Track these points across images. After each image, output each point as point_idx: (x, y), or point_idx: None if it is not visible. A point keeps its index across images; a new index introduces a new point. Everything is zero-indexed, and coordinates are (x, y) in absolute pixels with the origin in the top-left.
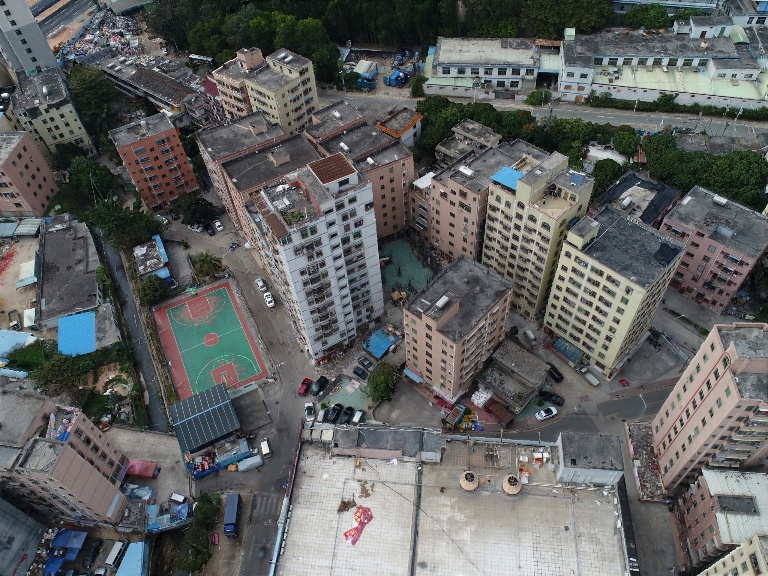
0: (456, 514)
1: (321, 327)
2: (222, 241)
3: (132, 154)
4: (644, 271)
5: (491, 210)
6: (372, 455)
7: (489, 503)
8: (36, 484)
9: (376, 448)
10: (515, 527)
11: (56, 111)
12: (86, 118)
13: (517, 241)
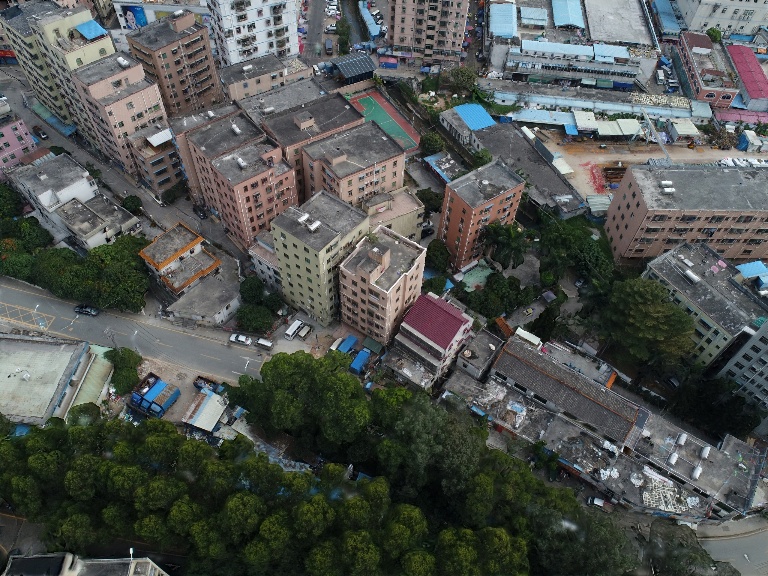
0: None
1: None
2: None
3: None
4: (36, 8)
5: None
6: None
7: None
8: None
9: None
10: None
11: None
12: None
13: None
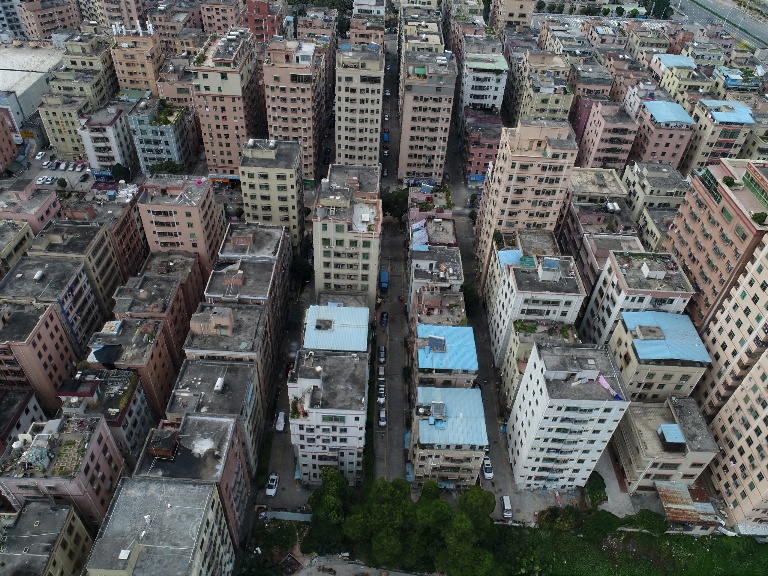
0: (8, 51)
1: None
2: None
3: None
4: None
5: None
6: None
7: None
8: None
9: None
10: (29, 53)
11: None
12: None
13: None
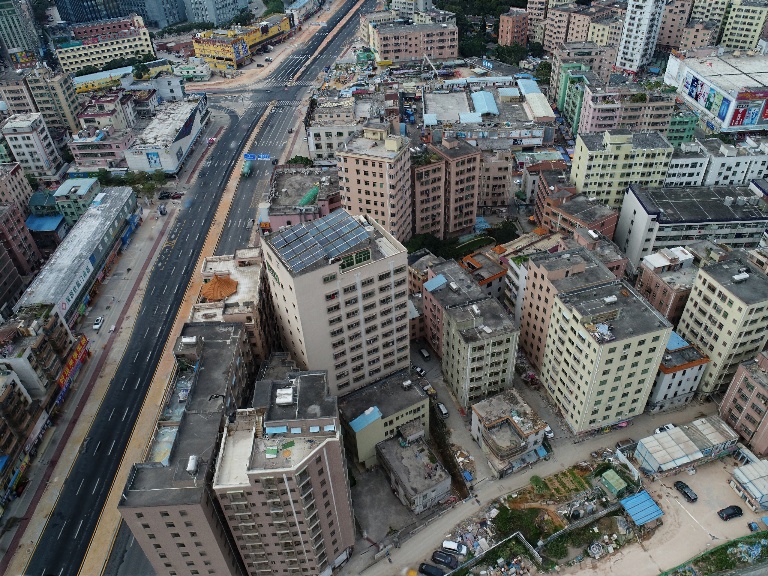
0: None
1: (645, 50)
2: (552, 61)
3: (515, 22)
4: None
5: (695, 8)
6: (701, 55)
7: (745, 58)
8: (600, 63)
9: (704, 49)
10: None
11: (450, 20)
12: (459, 26)
13: (707, 18)
